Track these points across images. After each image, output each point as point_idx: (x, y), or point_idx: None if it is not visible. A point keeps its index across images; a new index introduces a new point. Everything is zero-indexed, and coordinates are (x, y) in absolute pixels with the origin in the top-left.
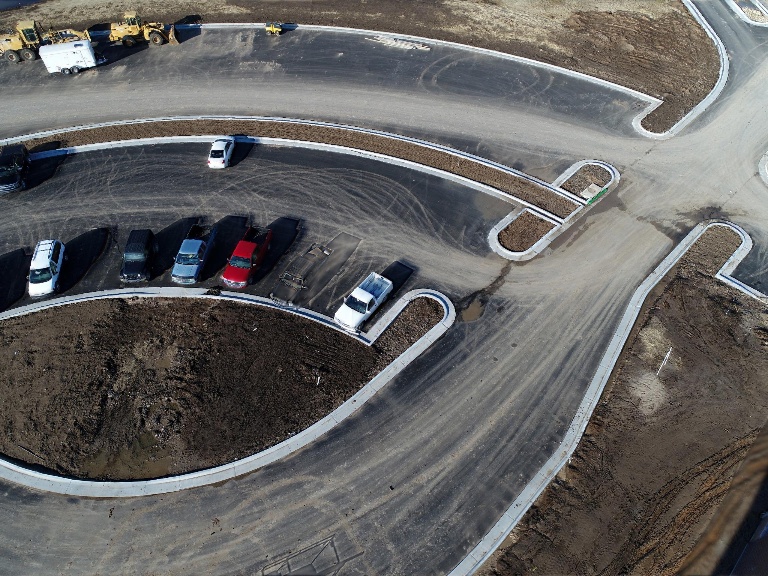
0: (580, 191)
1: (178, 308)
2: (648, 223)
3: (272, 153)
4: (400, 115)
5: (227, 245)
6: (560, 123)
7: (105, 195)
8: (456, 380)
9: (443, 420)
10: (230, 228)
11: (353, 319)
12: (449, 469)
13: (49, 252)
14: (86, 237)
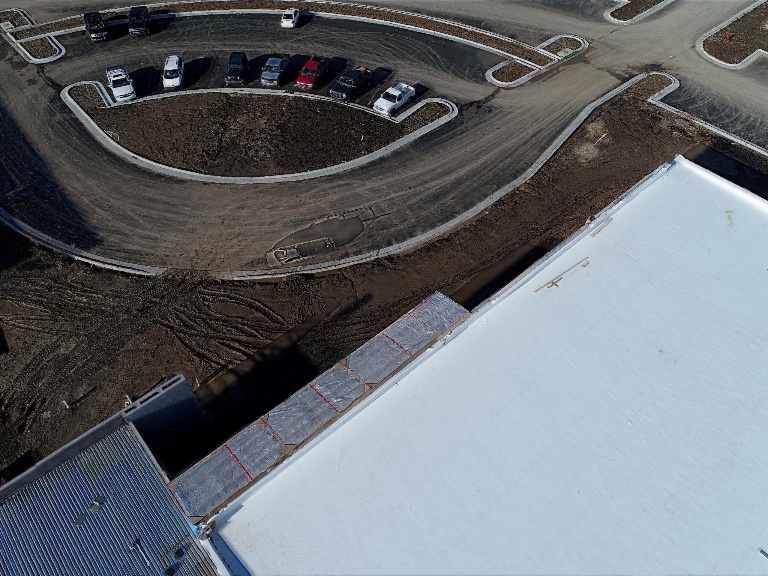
0: (557, 52)
1: (265, 100)
2: (605, 71)
3: (327, 22)
4: (425, 3)
5: (297, 69)
6: (548, 12)
7: (207, 40)
8: (456, 143)
9: (445, 160)
10: (299, 61)
11: (387, 105)
12: (448, 182)
13: (176, 61)
14: (197, 62)
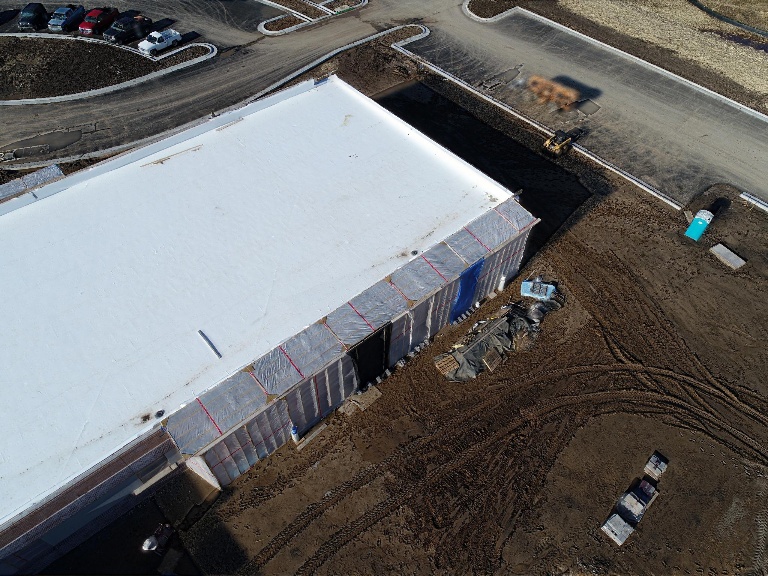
0: None
1: (49, 42)
2: (368, 23)
3: None
4: None
5: None
6: None
7: None
8: (199, 77)
9: (182, 90)
10: None
11: (147, 46)
12: (174, 106)
13: None
14: (5, 13)
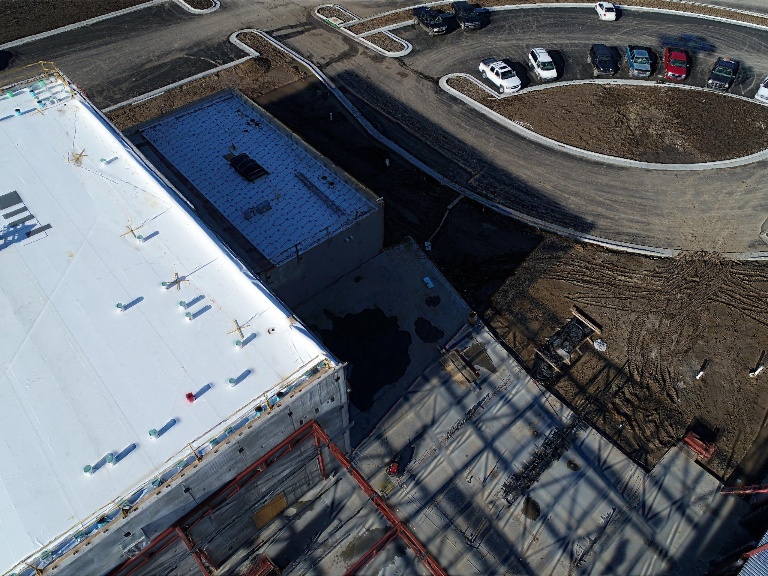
0: None
1: (641, 90)
2: None
3: (639, 15)
4: None
5: None
6: None
7: (538, 33)
8: None
9: None
10: None
11: None
12: None
13: (547, 53)
14: None
